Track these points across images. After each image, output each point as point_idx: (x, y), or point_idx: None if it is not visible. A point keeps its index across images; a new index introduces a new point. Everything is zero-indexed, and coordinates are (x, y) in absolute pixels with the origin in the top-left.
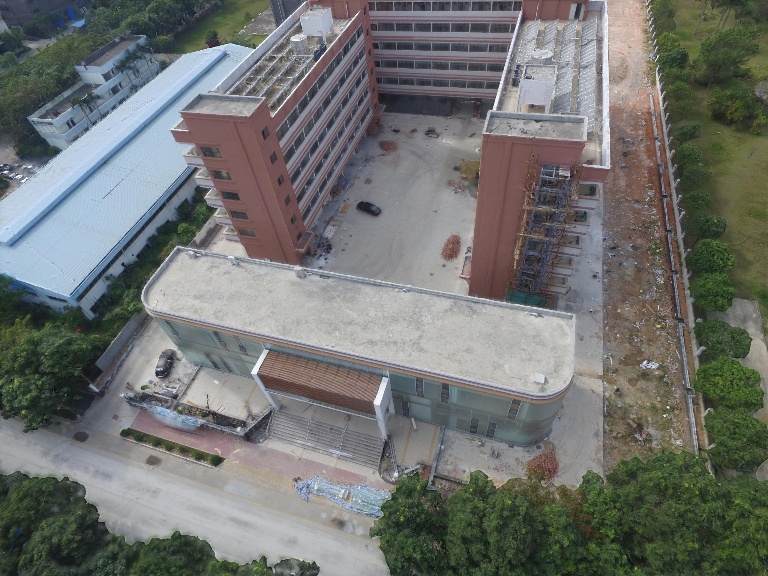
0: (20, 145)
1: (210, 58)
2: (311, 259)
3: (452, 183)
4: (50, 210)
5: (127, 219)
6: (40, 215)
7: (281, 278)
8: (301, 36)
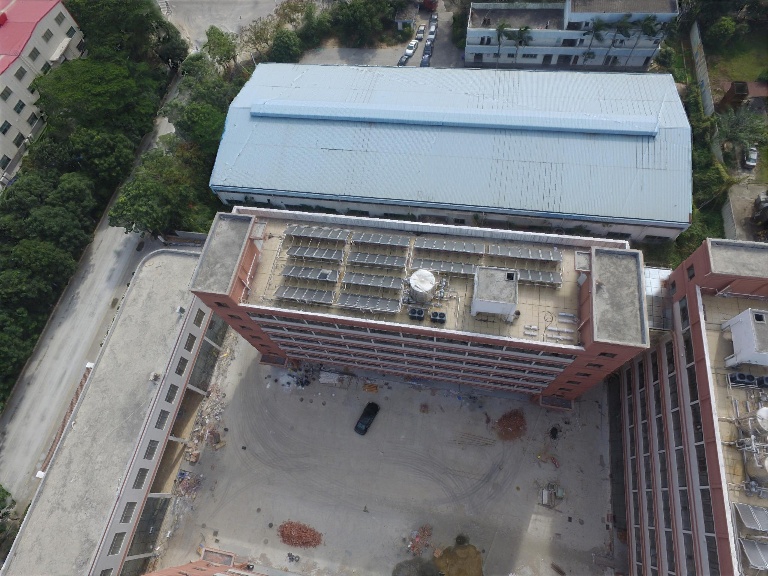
0: (456, 15)
1: (623, 123)
2: (289, 367)
3: (423, 533)
4: (296, 118)
5: (299, 181)
6: (286, 115)
7: (158, 361)
8: (426, 283)
